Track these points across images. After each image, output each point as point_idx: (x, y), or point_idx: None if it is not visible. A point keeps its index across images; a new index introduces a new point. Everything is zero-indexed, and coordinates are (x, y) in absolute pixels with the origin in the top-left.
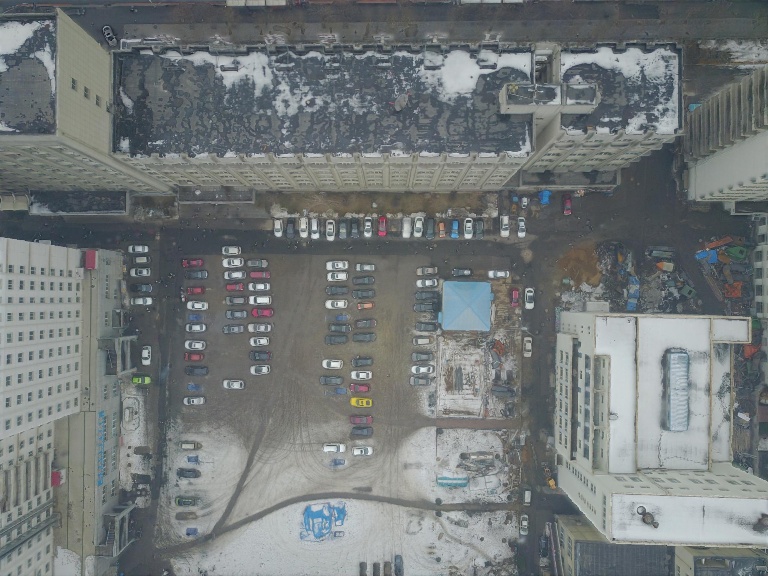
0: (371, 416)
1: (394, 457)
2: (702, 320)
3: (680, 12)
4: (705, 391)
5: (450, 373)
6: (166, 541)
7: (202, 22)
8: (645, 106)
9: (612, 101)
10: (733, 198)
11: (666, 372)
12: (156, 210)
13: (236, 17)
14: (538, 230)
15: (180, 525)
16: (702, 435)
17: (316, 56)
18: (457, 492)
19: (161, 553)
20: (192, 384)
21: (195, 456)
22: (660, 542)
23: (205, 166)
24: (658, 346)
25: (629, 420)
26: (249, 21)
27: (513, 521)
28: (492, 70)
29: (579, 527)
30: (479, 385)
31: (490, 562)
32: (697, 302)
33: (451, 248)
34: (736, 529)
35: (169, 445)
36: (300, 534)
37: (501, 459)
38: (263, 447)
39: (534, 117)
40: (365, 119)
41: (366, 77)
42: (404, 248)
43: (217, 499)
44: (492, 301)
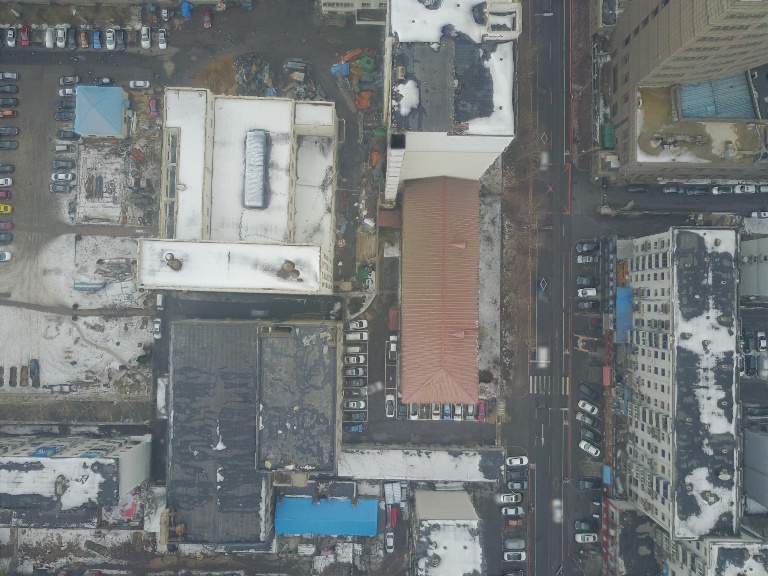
0: (10, 222)
1: (33, 263)
2: (285, 103)
3: None
4: (286, 171)
5: (91, 181)
6: None
7: None
8: None
9: None
10: (350, 3)
11: None
12: None
13: None
14: (180, 43)
15: None
16: (282, 214)
17: None
18: (94, 297)
19: None
20: None
21: None
22: (185, 287)
23: None
24: (242, 127)
25: (198, 191)
26: None
27: (149, 326)
28: None
29: (192, 320)
30: (119, 193)
31: (125, 366)
32: None
33: (95, 59)
34: (260, 275)
35: None
36: None
37: None
38: None
39: None
40: None
41: None
42: (49, 59)
43: None
44: (133, 111)
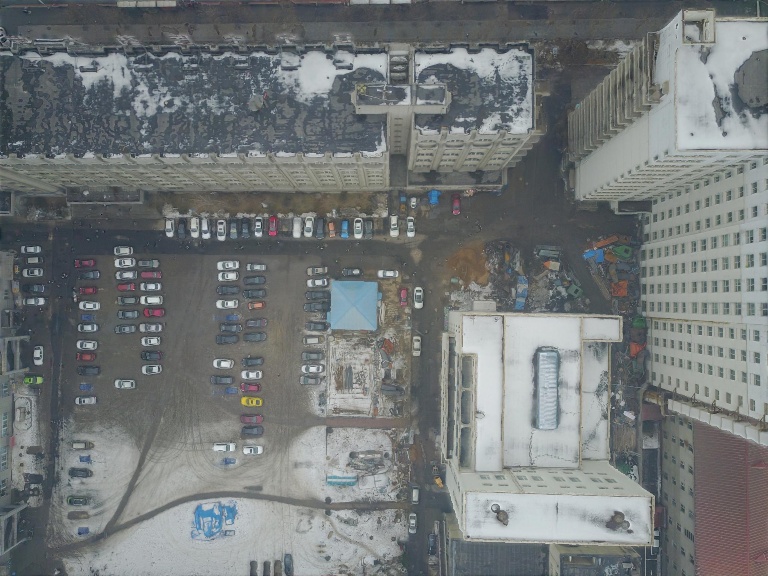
0: (261, 415)
1: (284, 456)
2: (573, 319)
3: (568, 12)
4: (576, 389)
5: (340, 372)
6: (58, 540)
7: (95, 23)
8: (499, 106)
9: (467, 101)
10: (615, 197)
11: (537, 371)
12: (49, 211)
13: (127, 18)
14: (428, 230)
15: (72, 524)
16: (573, 433)
17: (174, 57)
18: (347, 491)
19: (53, 552)
20: (84, 384)
21: (87, 456)
22: (513, 539)
23: (72, 167)
24: (529, 345)
25: (496, 418)
26: (141, 22)
27: (402, 520)
28: (348, 70)
29: None
30: (369, 384)
31: (379, 560)
32: (585, 301)
33: (342, 248)
34: (589, 526)
35: (61, 445)
36: (191, 533)
37: (390, 458)
38: (155, 446)
39: (388, 117)
40: (223, 119)
41: (224, 78)
42: (295, 248)
43: (109, 498)
44: (382, 300)
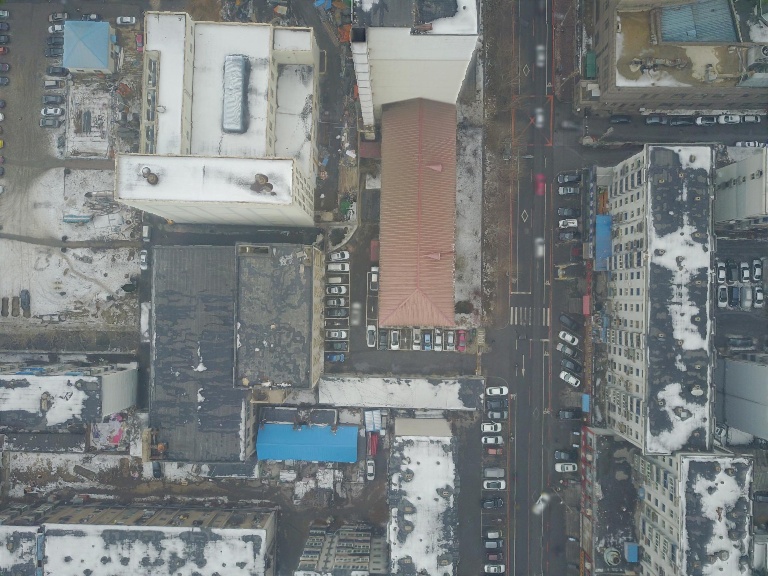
0: (2, 156)
1: (24, 197)
2: (263, 28)
3: None
4: (265, 96)
5: (79, 116)
6: None
7: None
8: None
9: None
10: None
11: None
12: None
13: None
14: None
15: None
16: (261, 138)
17: None
18: (82, 229)
19: None
20: None
21: None
22: (161, 200)
23: None
24: (221, 53)
25: (177, 113)
26: None
27: (135, 257)
28: None
29: None
30: (106, 128)
31: (112, 297)
32: None
33: None
34: (234, 188)
35: None
36: None
37: None
38: None
39: None
40: None
41: None
42: None
43: None
44: (120, 47)
